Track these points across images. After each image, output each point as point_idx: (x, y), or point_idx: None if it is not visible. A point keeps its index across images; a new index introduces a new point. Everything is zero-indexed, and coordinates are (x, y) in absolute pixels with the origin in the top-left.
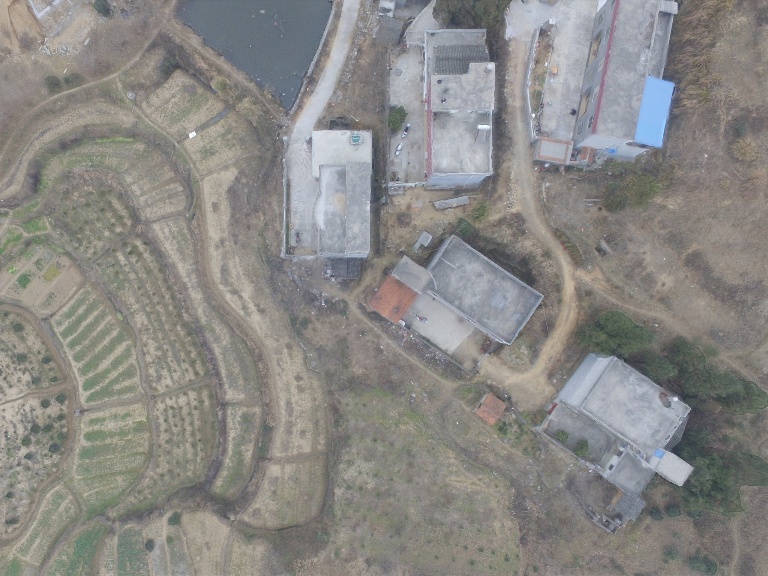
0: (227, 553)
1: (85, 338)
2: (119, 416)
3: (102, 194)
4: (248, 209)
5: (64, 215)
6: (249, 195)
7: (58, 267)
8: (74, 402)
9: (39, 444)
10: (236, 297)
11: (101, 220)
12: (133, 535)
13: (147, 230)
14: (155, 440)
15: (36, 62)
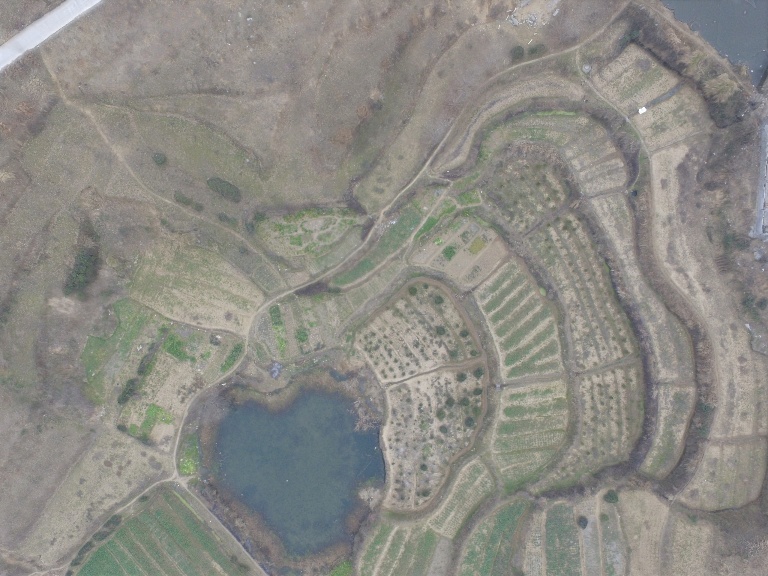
0: (668, 533)
1: (508, 313)
2: (540, 392)
3: (537, 168)
4: (698, 187)
5: (497, 188)
6: (701, 173)
7: (484, 240)
8: (488, 377)
9: (452, 418)
10: (682, 276)
11: (534, 194)
12: (564, 511)
13: (586, 205)
14: (581, 417)
15: (501, 32)
